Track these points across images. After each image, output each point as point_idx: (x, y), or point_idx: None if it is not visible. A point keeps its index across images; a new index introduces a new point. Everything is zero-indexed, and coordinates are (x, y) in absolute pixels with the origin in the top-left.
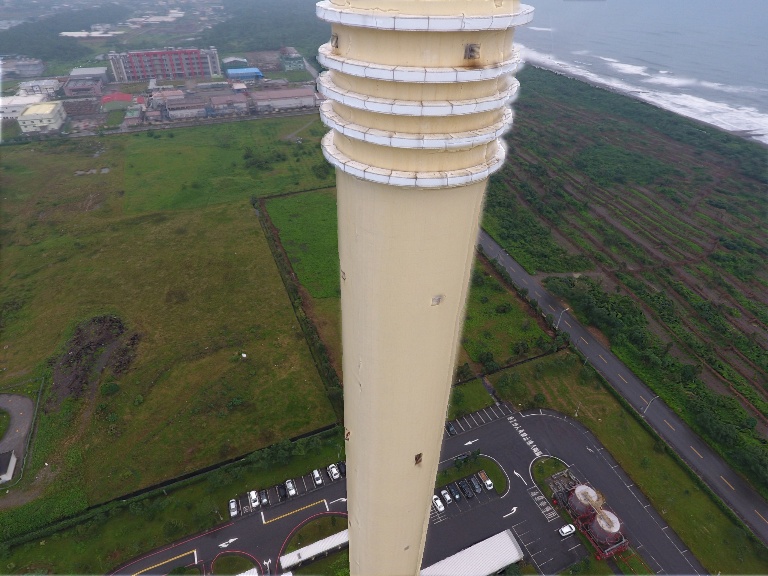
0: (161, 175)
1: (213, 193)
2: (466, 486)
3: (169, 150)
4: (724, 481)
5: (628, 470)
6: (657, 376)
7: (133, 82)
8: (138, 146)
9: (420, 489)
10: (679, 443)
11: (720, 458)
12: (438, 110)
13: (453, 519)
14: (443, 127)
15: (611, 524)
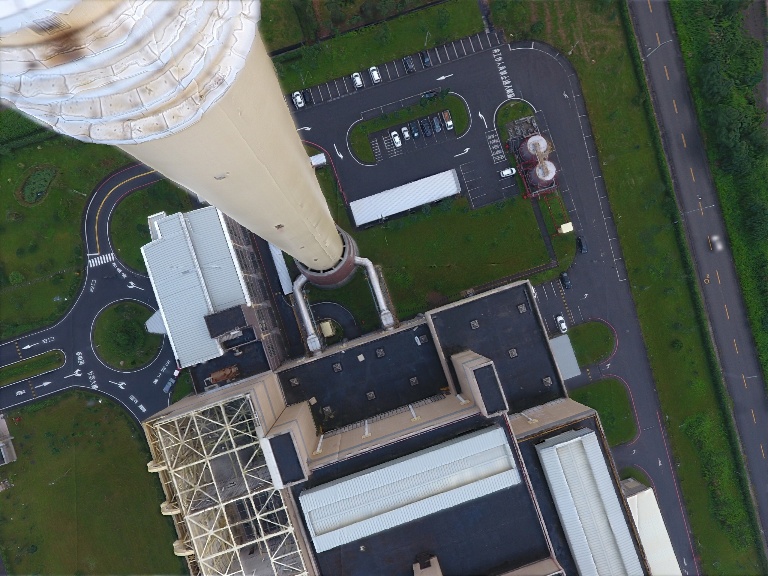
0: None
1: None
2: (427, 125)
3: None
4: (682, 139)
5: (593, 121)
6: (693, 6)
7: None
8: None
9: (296, 230)
10: (664, 95)
11: (695, 115)
12: (49, 99)
13: (408, 155)
14: (86, 91)
15: (547, 174)
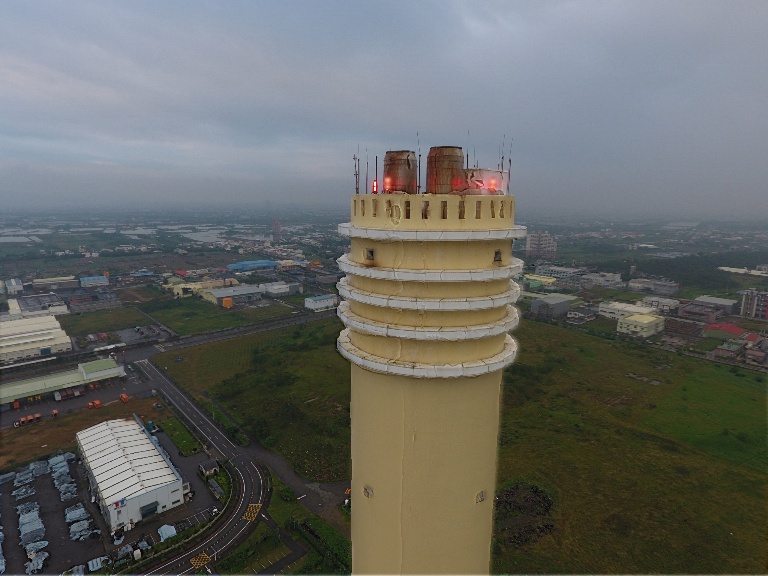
0: (709, 410)
1: (761, 457)
2: None
3: (743, 392)
4: None
5: None
6: None
7: (760, 320)
8: (709, 375)
9: None
10: None
11: None
12: None
13: None
14: None
15: None
